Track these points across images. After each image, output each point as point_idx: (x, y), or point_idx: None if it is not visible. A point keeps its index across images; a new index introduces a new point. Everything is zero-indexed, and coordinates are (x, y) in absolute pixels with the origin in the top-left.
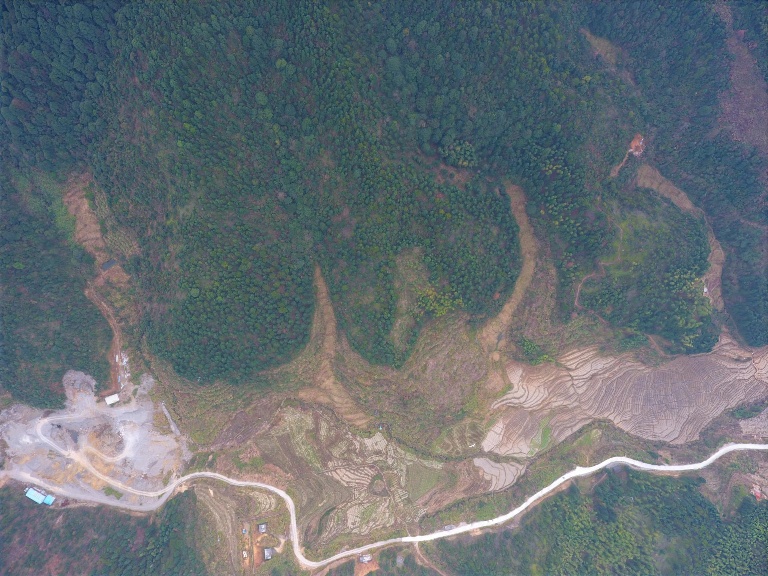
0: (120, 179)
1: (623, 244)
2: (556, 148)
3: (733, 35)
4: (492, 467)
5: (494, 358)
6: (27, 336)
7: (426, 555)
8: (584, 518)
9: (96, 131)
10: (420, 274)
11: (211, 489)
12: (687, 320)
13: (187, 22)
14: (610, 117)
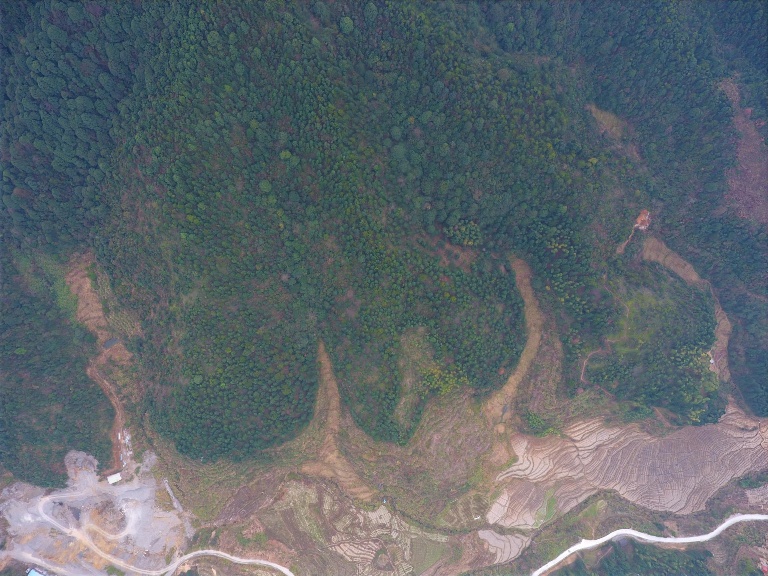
0: (123, 264)
1: (629, 322)
2: (562, 227)
3: (740, 113)
4: (497, 539)
5: (499, 430)
6: (29, 421)
7: None
8: None
9: (98, 215)
10: (425, 352)
11: (214, 568)
12: (694, 396)
13: (191, 120)
14: (616, 197)
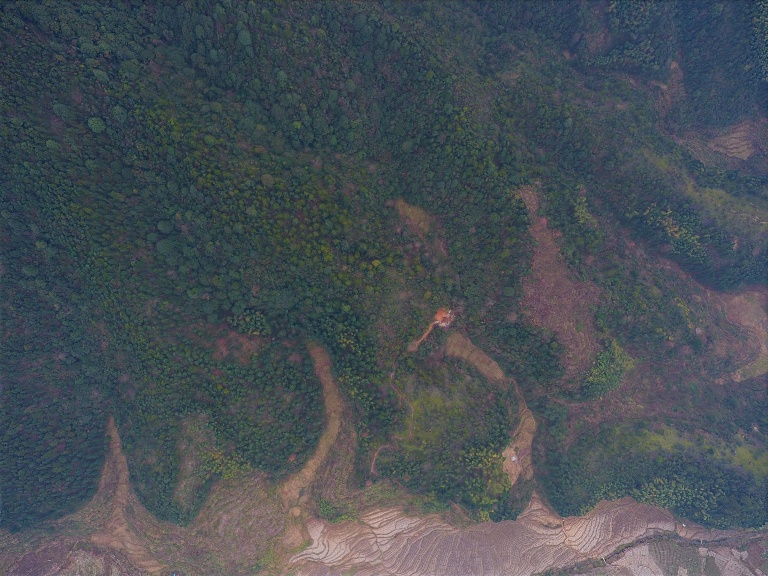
0: None
1: (413, 422)
2: (348, 324)
3: (537, 221)
4: None
5: (294, 513)
6: None
7: None
8: None
9: None
10: (209, 436)
11: None
12: (481, 497)
13: None
14: (403, 299)
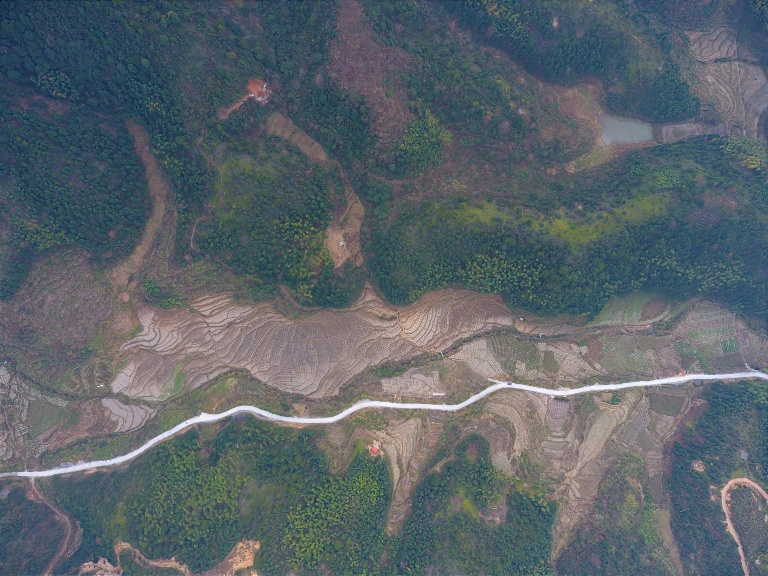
0: None
1: (222, 186)
2: (152, 84)
3: None
4: (120, 408)
5: (123, 299)
6: None
7: (40, 491)
8: (188, 461)
9: None
10: (24, 205)
11: None
12: (299, 269)
13: None
14: (204, 56)
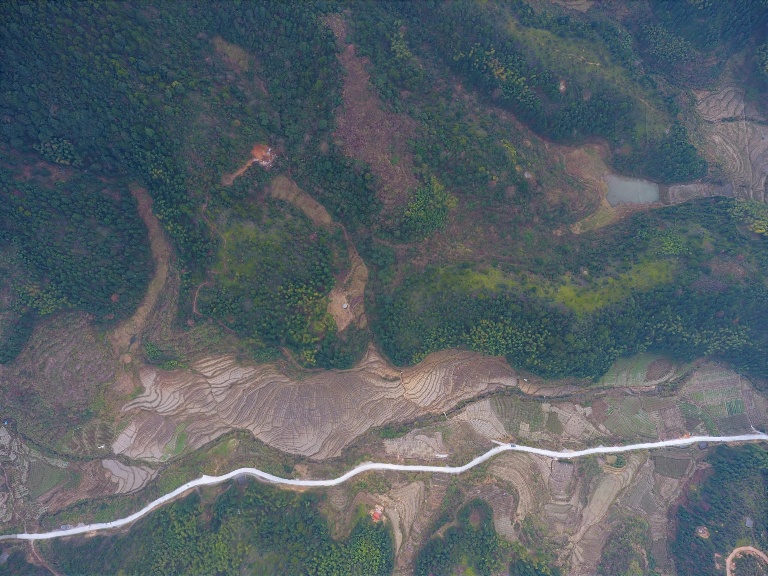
0: None
1: (226, 254)
2: (156, 152)
3: (346, 49)
4: (121, 470)
5: (125, 360)
6: None
7: (40, 553)
8: (189, 527)
9: None
10: (26, 271)
11: None
12: (302, 335)
13: None
14: (208, 124)
